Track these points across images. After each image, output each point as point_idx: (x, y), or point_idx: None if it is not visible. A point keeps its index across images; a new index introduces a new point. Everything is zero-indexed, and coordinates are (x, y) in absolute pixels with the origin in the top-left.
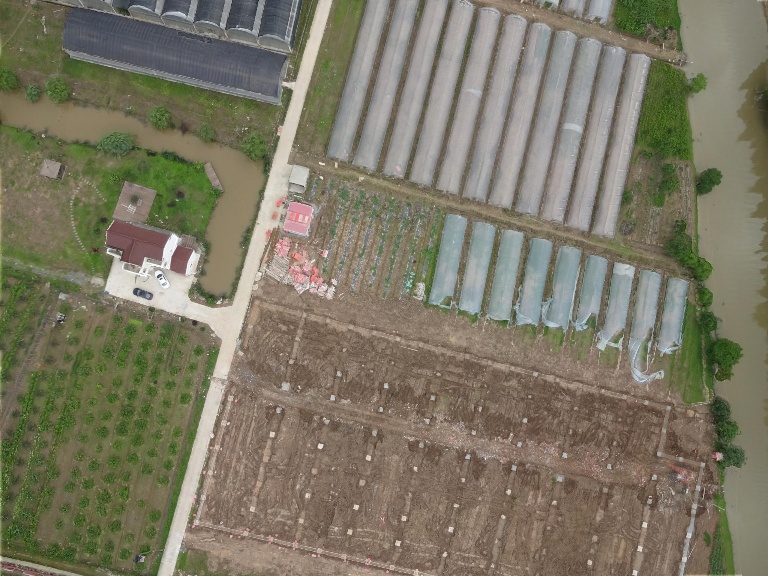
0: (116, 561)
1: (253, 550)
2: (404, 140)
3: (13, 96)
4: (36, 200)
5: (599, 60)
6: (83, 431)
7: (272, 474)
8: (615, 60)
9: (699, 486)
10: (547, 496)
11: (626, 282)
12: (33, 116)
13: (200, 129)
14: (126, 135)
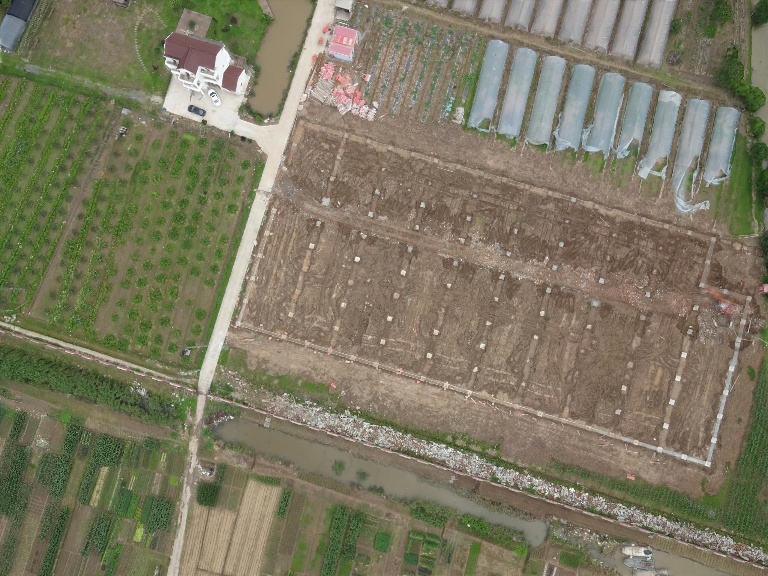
0: (164, 354)
1: (290, 352)
2: None
3: None
4: (105, 25)
5: None
6: (139, 234)
7: (310, 282)
8: None
9: (744, 319)
10: (581, 319)
11: (672, 111)
12: None
13: None
14: None
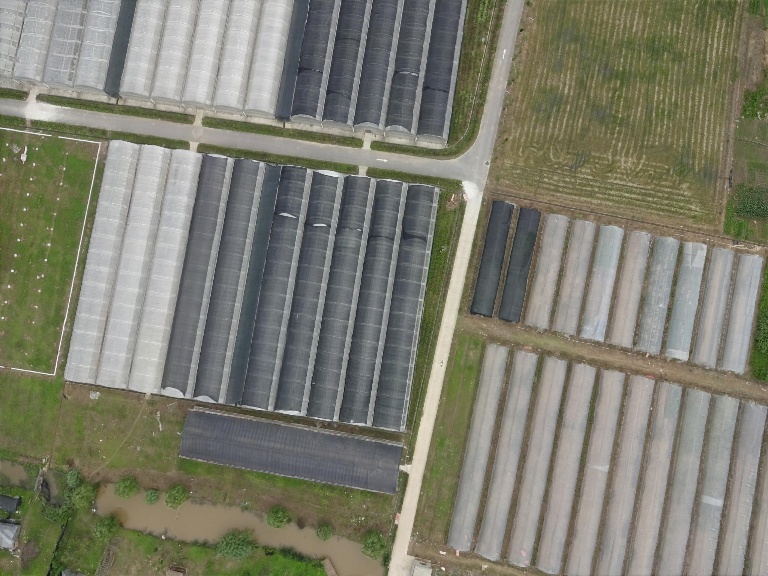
0: None
1: None
2: (528, 521)
3: (133, 498)
4: None
5: (737, 416)
6: None
7: None
8: (757, 421)
9: None
10: None
11: None
12: (153, 516)
13: (317, 524)
14: (244, 537)
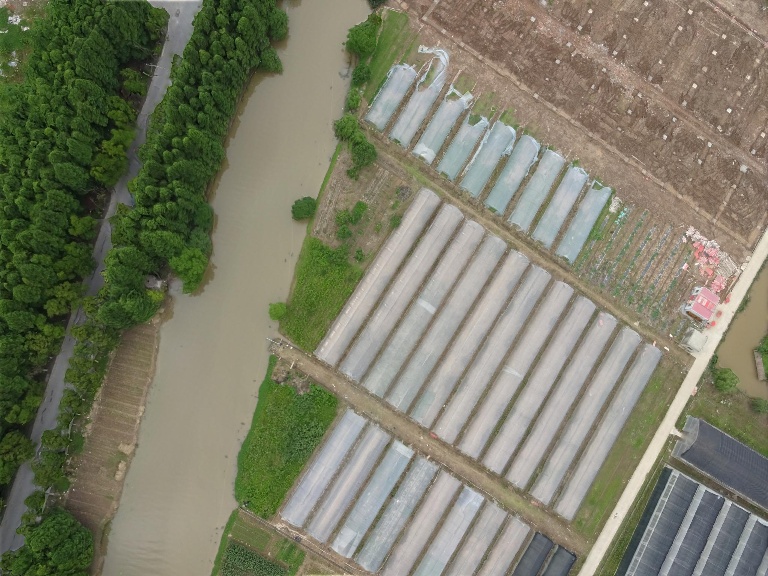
0: None
1: None
2: (589, 348)
3: None
4: None
5: (369, 371)
6: None
7: None
8: (359, 363)
9: None
10: None
11: None
12: None
13: (762, 413)
14: None
